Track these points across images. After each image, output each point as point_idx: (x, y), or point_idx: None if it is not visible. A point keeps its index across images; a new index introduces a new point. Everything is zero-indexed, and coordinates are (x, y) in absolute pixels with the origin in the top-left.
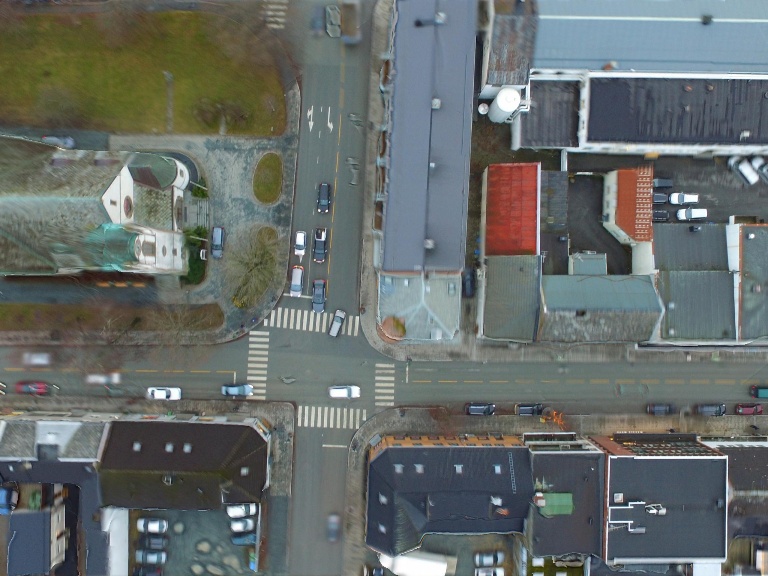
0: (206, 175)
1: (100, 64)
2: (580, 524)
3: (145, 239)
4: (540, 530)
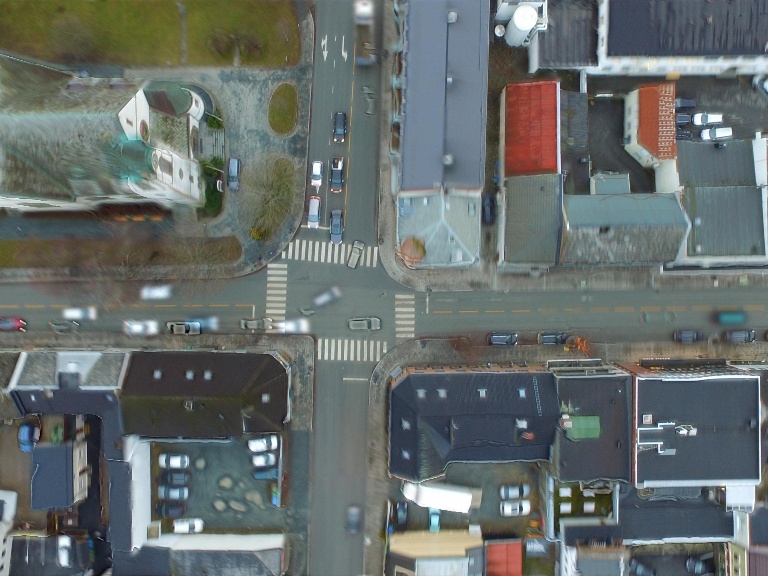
0: (221, 107)
1: None
2: (608, 448)
3: (162, 155)
4: (567, 454)
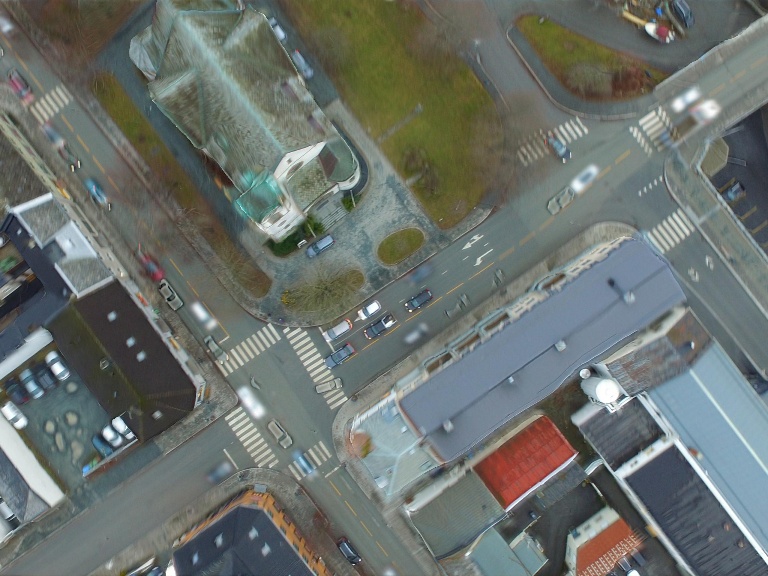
0: (366, 196)
1: (387, 49)
2: None
3: (281, 211)
4: None
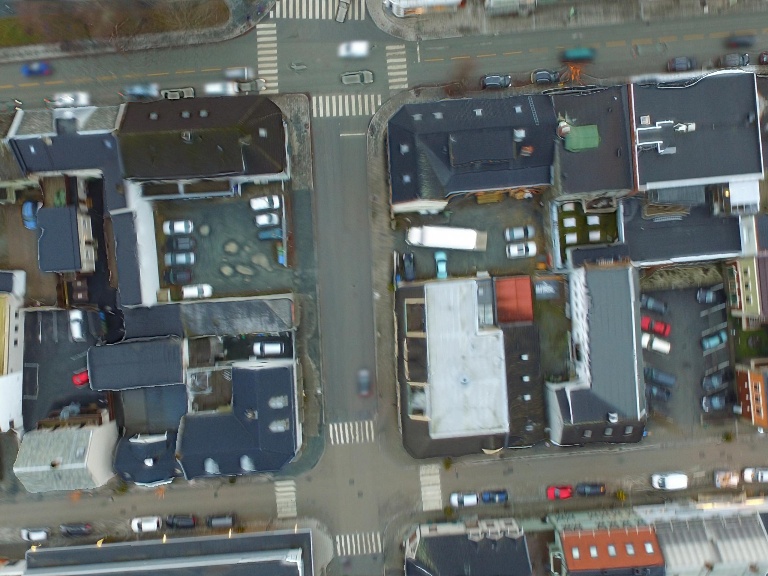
0: None
1: None
2: (608, 157)
3: None
4: (567, 165)
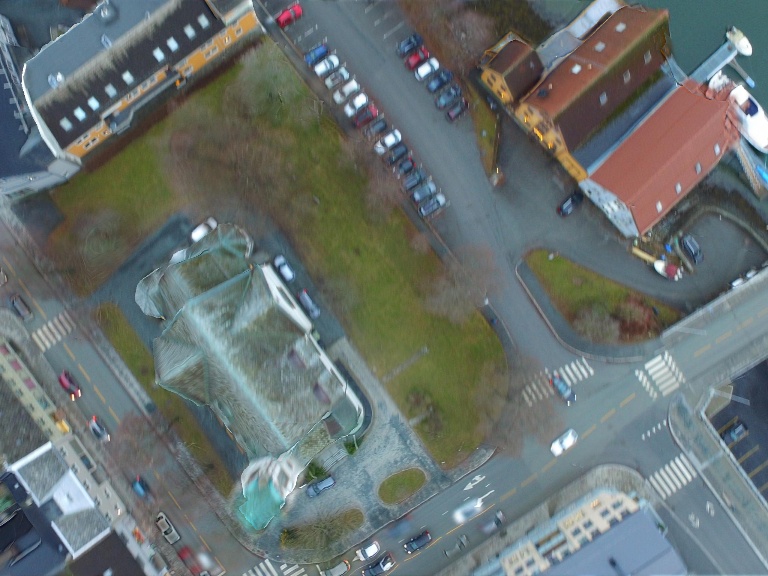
0: (368, 436)
1: (396, 287)
2: None
3: None
4: None
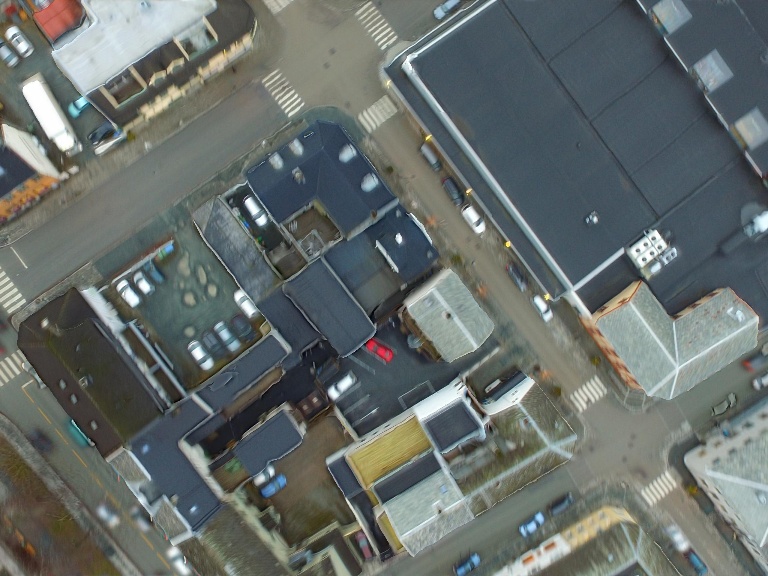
0: None
1: None
2: None
3: None
4: None
